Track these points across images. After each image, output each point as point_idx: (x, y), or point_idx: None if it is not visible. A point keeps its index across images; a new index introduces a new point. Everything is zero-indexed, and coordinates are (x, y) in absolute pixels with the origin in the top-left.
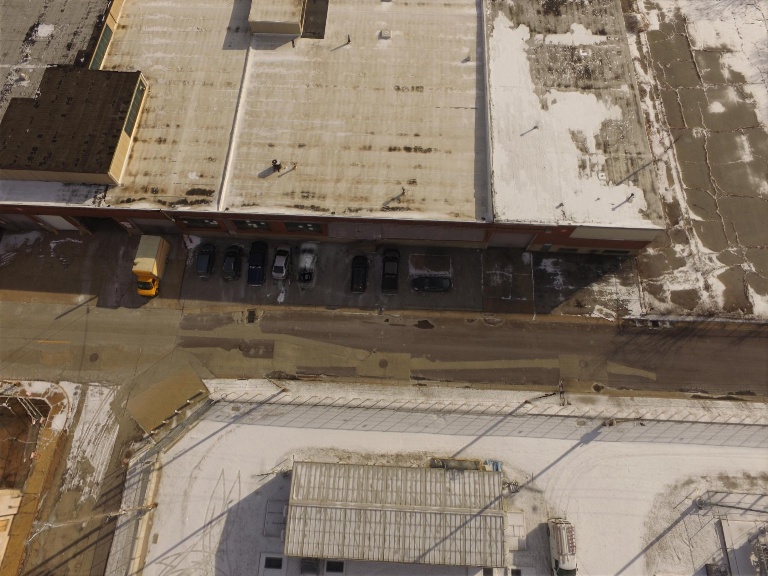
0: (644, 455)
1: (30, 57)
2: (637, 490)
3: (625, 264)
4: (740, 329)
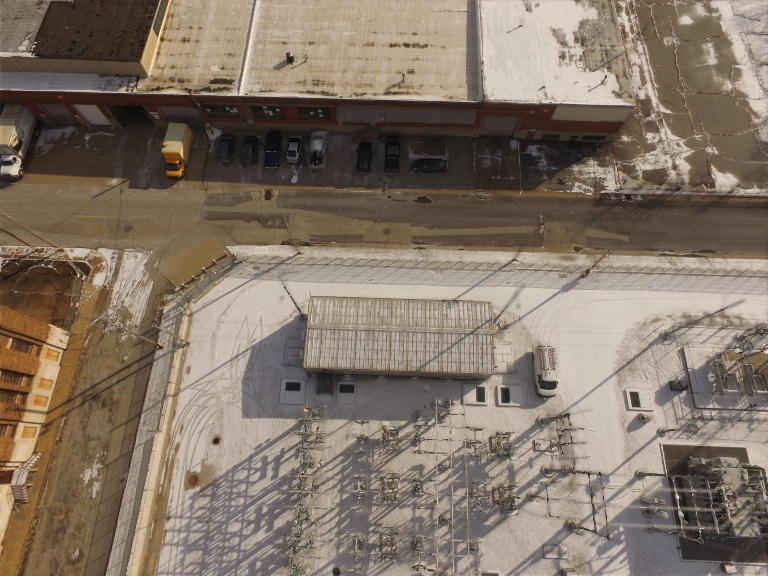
0: (617, 299)
1: None
2: (611, 326)
3: (602, 149)
4: (703, 200)
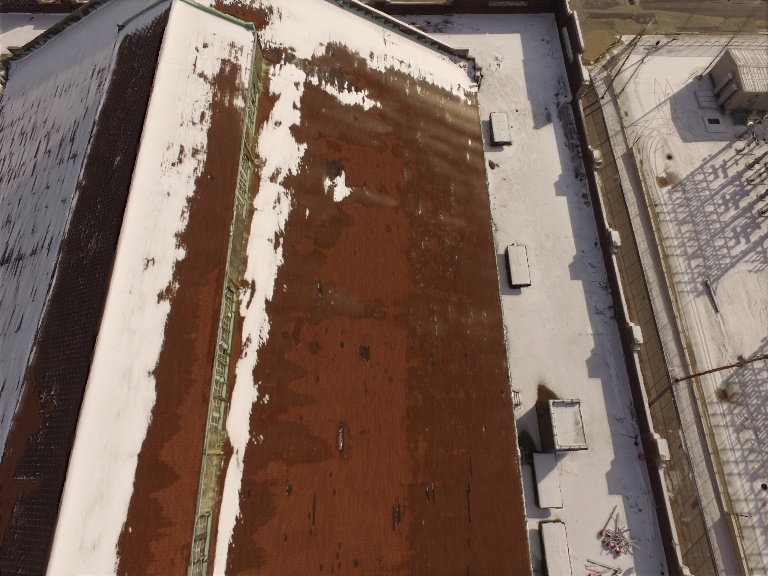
0: None
1: None
2: None
3: None
4: None
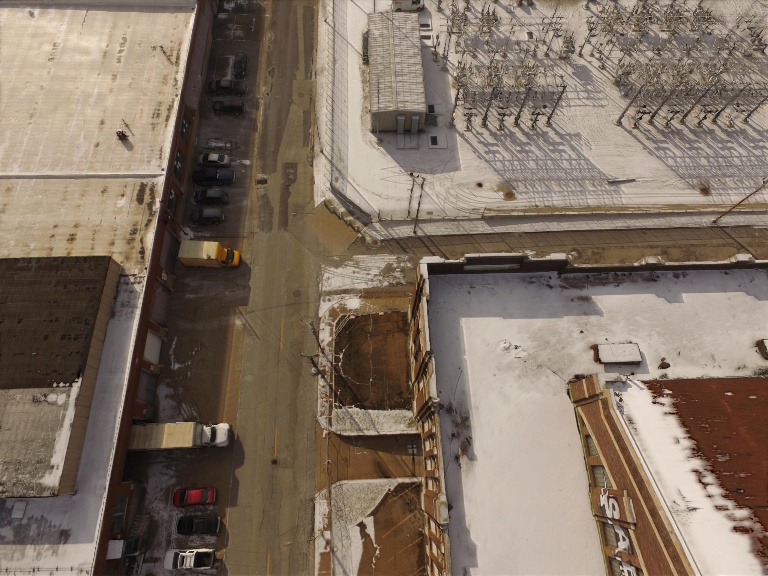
0: None
1: None
2: None
3: None
4: None
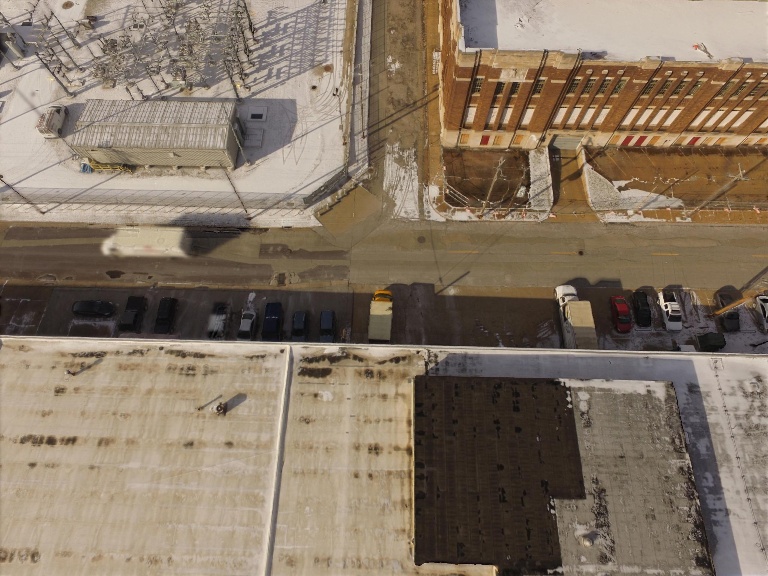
0: None
1: None
2: None
3: None
4: None
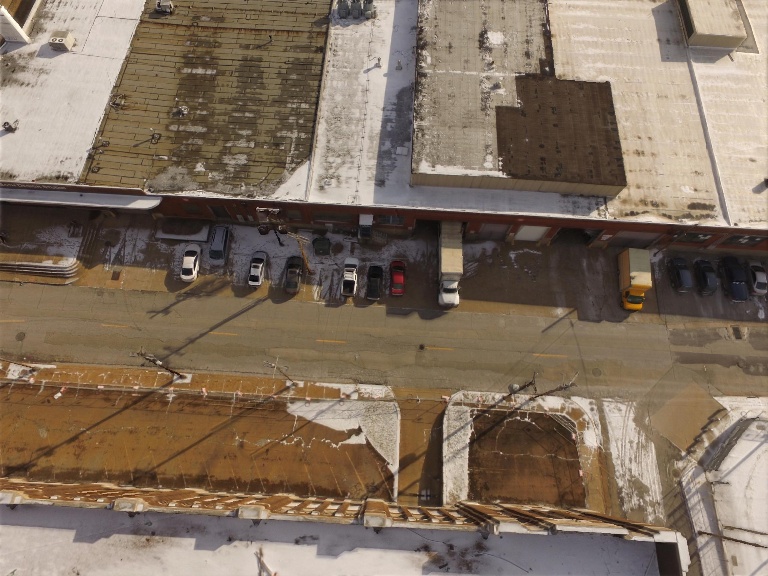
0: None
1: (494, 65)
2: None
3: None
4: None
